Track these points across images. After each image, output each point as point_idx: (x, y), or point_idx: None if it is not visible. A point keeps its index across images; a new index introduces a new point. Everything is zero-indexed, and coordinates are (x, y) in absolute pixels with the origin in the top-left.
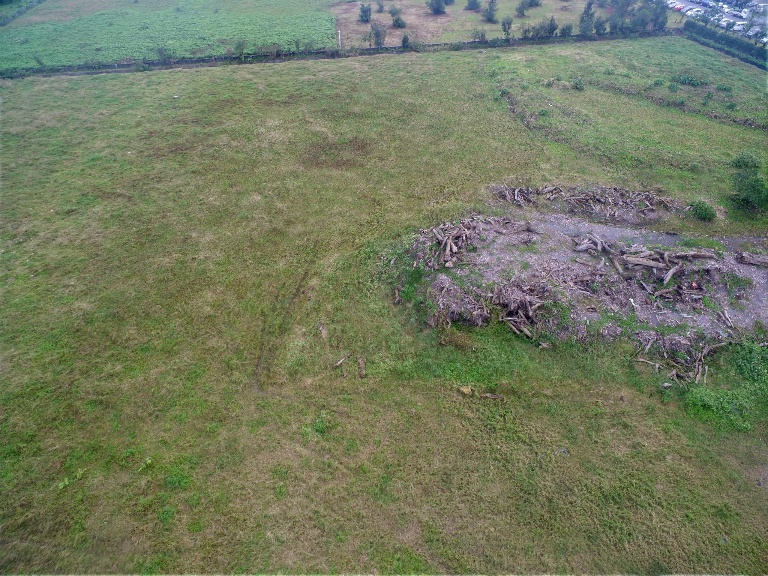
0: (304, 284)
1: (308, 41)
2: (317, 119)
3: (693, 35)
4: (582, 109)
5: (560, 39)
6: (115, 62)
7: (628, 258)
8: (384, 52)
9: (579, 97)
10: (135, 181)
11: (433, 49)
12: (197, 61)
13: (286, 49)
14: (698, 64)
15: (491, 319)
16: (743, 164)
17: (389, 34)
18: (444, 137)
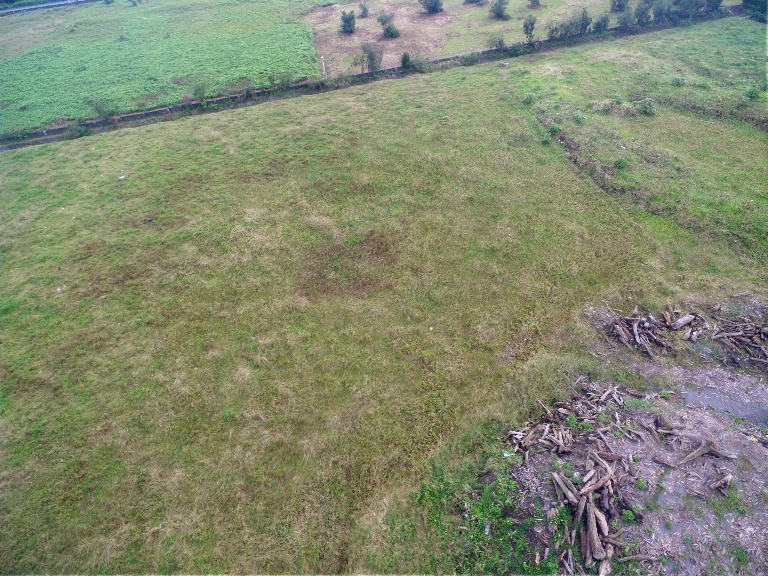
0: None
1: (284, 70)
2: (313, 201)
3: (758, 14)
4: (665, 148)
5: (595, 36)
6: (43, 128)
7: None
8: (381, 76)
9: (653, 127)
10: (64, 351)
11: (441, 66)
12: (147, 115)
13: (258, 85)
14: None
15: None
16: None
17: (382, 48)
18: (494, 218)
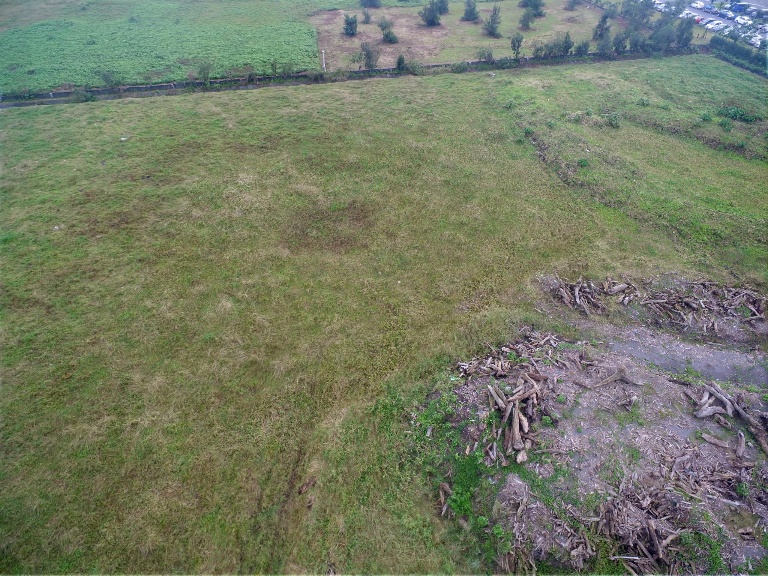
0: (300, 473)
1: (286, 61)
2: (303, 172)
3: (722, 54)
4: (625, 155)
5: (576, 58)
6: (50, 90)
7: None
8: (376, 75)
9: (617, 137)
10: (59, 277)
11: (433, 71)
12: (152, 88)
13: (260, 71)
14: (742, 92)
15: (597, 558)
16: None
17: (380, 51)
18: (465, 199)
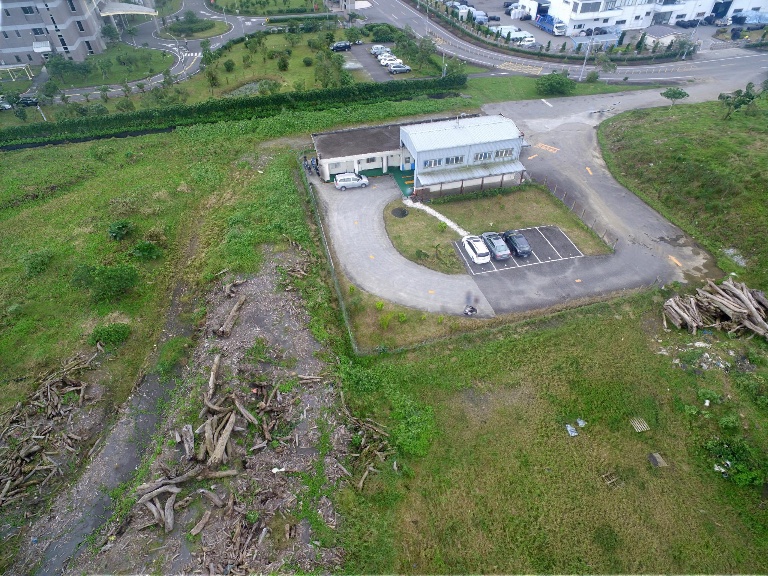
0: None
1: None
2: None
3: None
4: None
5: None
6: None
7: (216, 457)
8: None
9: None
10: None
11: None
12: None
13: None
14: None
15: None
16: (41, 266)
17: None
18: None
